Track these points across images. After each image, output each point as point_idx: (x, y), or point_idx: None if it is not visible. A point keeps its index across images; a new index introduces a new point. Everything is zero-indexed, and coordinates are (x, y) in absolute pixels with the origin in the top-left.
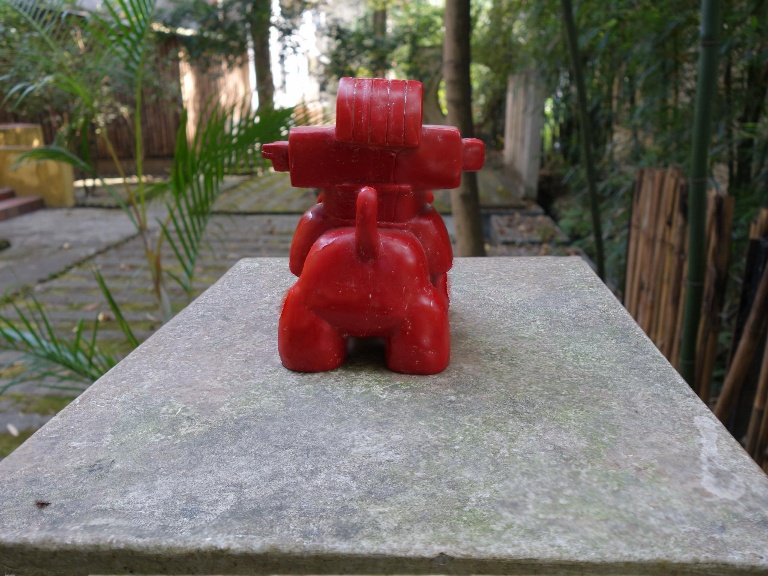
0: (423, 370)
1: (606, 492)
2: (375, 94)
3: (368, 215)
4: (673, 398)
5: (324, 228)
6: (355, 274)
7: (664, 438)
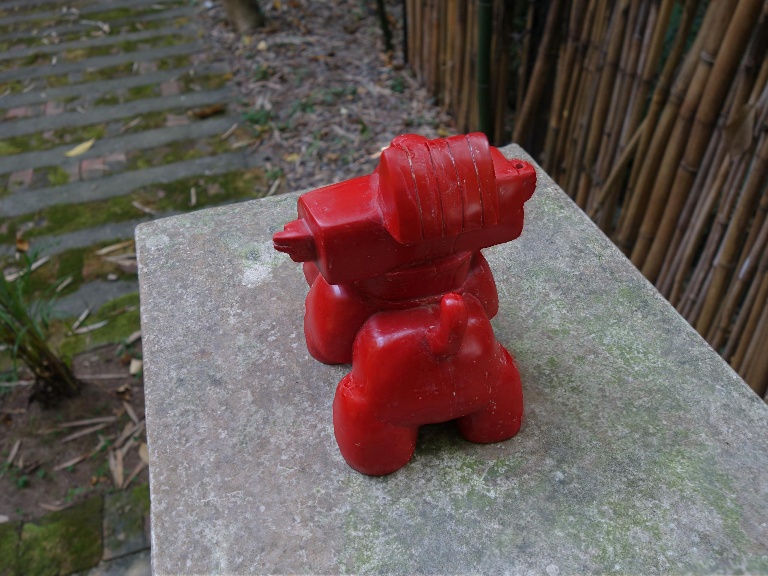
0: (507, 436)
1: None
2: (440, 172)
3: (462, 333)
4: (743, 408)
5: (368, 313)
6: (435, 377)
7: None
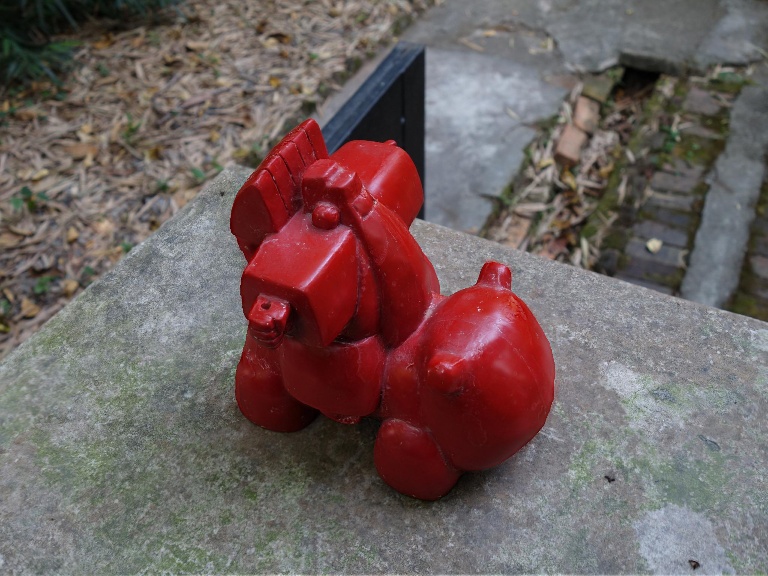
0: None
1: (7, 416)
2: None
3: None
4: None
5: None
6: None
7: (8, 504)
